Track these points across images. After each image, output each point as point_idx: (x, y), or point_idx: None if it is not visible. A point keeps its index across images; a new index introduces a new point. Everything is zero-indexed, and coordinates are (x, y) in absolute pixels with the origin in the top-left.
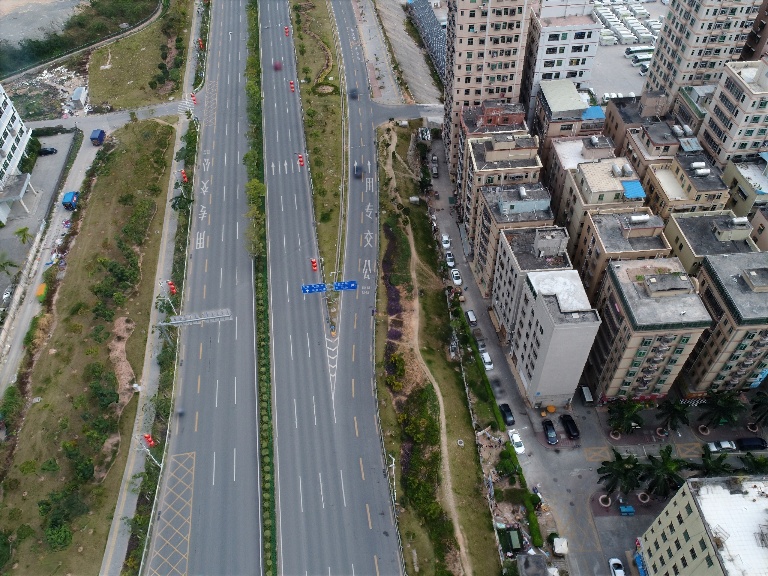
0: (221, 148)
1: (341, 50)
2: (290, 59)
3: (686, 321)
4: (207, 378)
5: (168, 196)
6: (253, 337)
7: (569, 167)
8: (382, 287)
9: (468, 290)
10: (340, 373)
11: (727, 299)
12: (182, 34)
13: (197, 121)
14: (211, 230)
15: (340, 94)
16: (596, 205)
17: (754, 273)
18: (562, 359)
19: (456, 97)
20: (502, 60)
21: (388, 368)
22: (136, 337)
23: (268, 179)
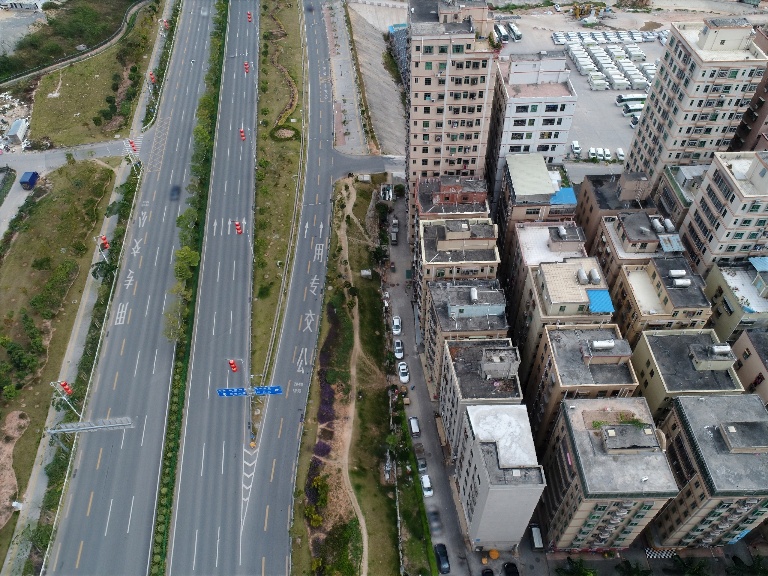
0: (162, 199)
1: (309, 87)
2: (252, 95)
3: (647, 491)
4: (101, 496)
5: (94, 256)
6: (161, 444)
7: (532, 261)
8: (316, 385)
9: (415, 389)
10: (254, 497)
11: (699, 459)
12: (141, 60)
13: (140, 166)
14: (135, 302)
15: (301, 139)
16: (556, 318)
17: (733, 429)
18: (502, 514)
19: (412, 167)
20: (464, 130)
21: (309, 494)
22: (28, 438)
23: (207, 240)
